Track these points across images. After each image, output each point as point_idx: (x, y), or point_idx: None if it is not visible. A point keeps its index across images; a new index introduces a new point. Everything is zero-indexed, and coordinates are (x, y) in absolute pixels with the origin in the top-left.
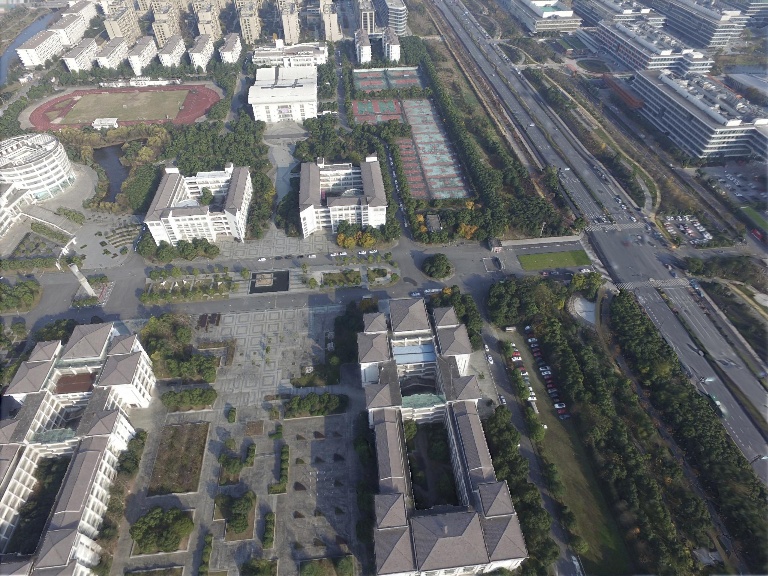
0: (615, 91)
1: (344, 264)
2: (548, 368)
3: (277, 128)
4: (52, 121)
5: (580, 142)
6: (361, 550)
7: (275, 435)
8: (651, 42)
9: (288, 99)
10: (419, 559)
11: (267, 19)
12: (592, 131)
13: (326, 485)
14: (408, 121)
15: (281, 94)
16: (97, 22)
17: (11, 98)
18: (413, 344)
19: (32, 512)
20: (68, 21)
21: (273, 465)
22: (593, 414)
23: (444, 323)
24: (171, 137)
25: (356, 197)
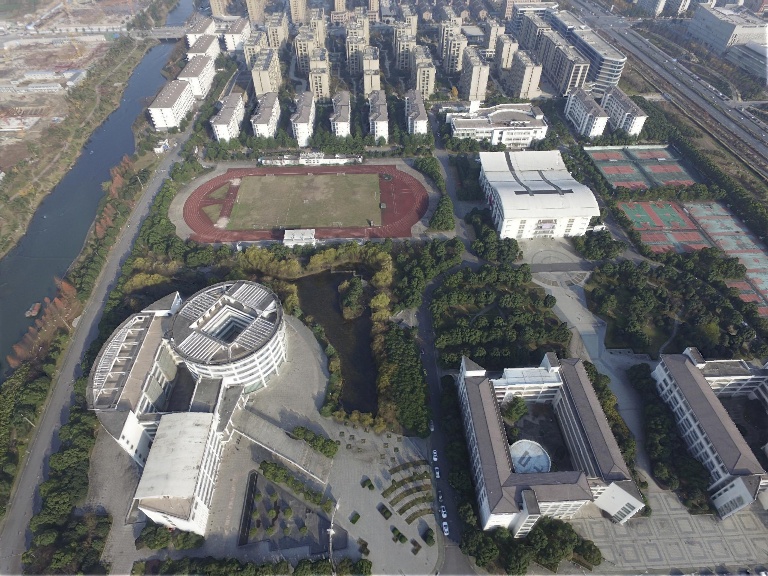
0: None
1: None
2: None
3: (535, 251)
4: (216, 223)
5: None
6: None
7: None
8: None
9: (560, 213)
10: None
11: None
12: None
13: None
14: (721, 246)
15: (548, 205)
16: (223, 62)
17: (150, 179)
18: None
19: None
20: (200, 65)
21: None
22: None
23: None
24: (392, 262)
25: None
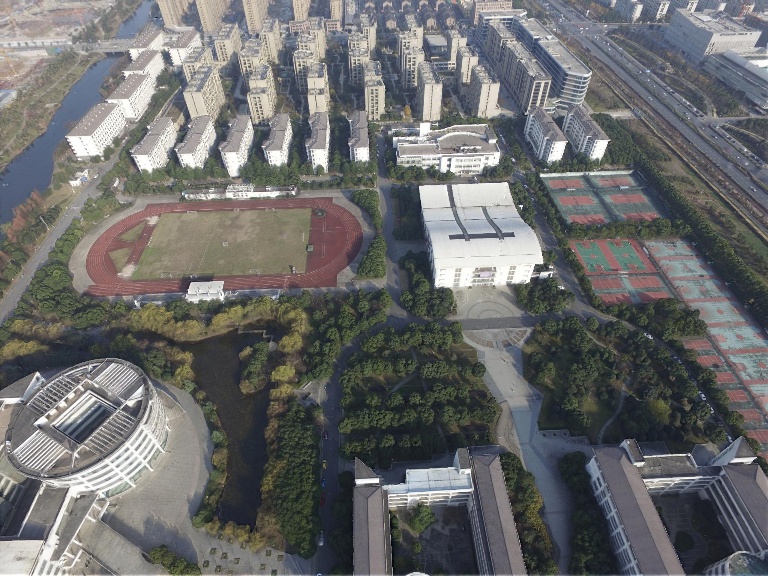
0: None
1: None
2: None
3: (472, 302)
4: (120, 272)
5: None
6: None
7: None
8: None
9: (498, 262)
10: None
11: (383, 76)
12: None
13: None
14: (681, 294)
15: (485, 252)
16: (166, 79)
17: (58, 218)
18: None
19: None
20: (133, 85)
21: None
22: None
23: None
24: (309, 319)
25: None
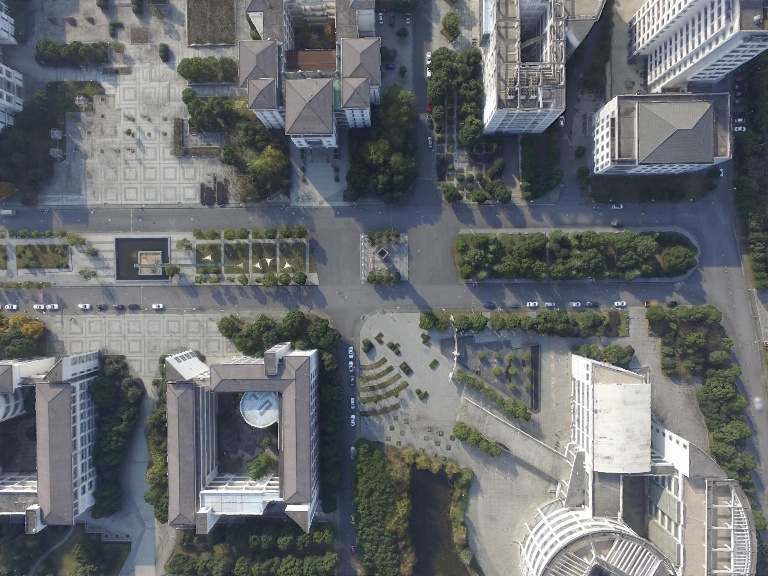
0: None
1: None
2: None
3: None
4: None
5: None
6: None
7: (115, 23)
8: None
9: None
10: None
11: None
12: None
13: None
14: None
15: None
16: None
17: None
18: None
19: None
20: None
21: None
22: None
23: None
24: None
25: None
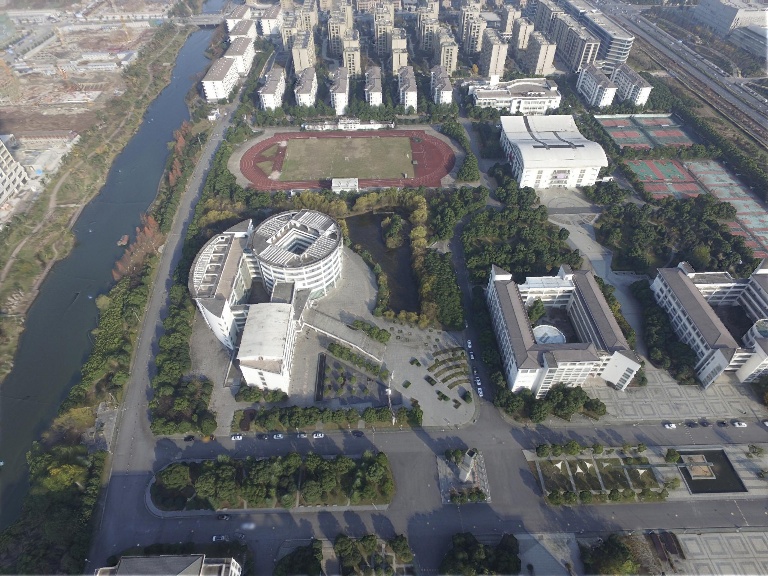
0: None
1: None
2: None
3: (550, 198)
4: (269, 176)
5: None
6: None
7: None
8: None
9: (573, 164)
10: None
11: None
12: None
13: None
14: (715, 194)
15: (563, 157)
16: (261, 44)
17: (207, 141)
18: None
19: None
20: (243, 45)
21: None
22: None
23: None
24: None
25: None
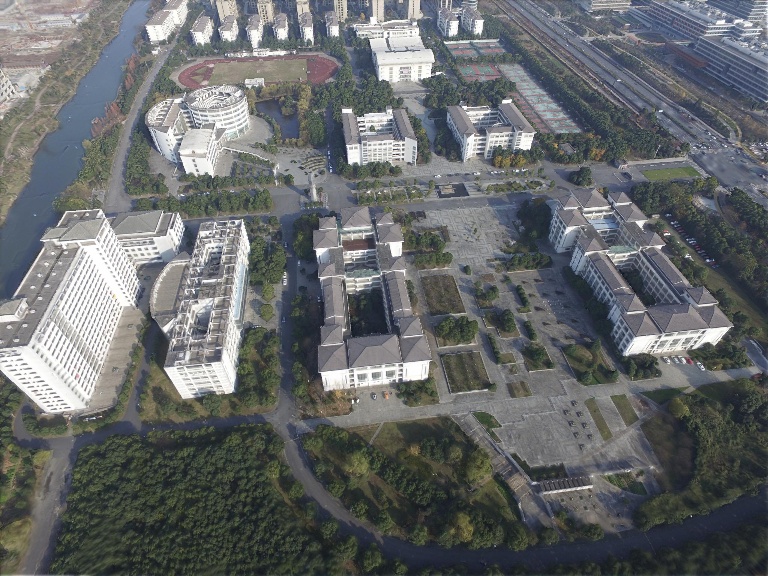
0: (677, 56)
1: (505, 178)
2: (693, 239)
3: (399, 86)
4: (201, 83)
5: (661, 93)
6: (601, 340)
7: (507, 281)
8: (705, 14)
9: (411, 61)
10: (662, 326)
11: None
12: (669, 85)
13: (558, 308)
14: (510, 80)
15: (404, 57)
16: (193, 5)
17: (152, 66)
18: (597, 218)
19: (361, 321)
20: (177, 3)
21: (514, 297)
22: (742, 259)
23: (621, 201)
24: (312, 94)
25: (510, 126)
